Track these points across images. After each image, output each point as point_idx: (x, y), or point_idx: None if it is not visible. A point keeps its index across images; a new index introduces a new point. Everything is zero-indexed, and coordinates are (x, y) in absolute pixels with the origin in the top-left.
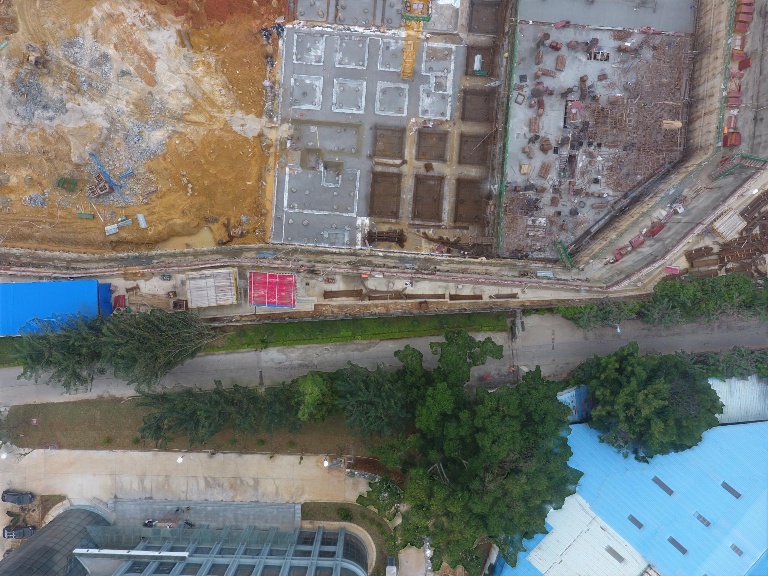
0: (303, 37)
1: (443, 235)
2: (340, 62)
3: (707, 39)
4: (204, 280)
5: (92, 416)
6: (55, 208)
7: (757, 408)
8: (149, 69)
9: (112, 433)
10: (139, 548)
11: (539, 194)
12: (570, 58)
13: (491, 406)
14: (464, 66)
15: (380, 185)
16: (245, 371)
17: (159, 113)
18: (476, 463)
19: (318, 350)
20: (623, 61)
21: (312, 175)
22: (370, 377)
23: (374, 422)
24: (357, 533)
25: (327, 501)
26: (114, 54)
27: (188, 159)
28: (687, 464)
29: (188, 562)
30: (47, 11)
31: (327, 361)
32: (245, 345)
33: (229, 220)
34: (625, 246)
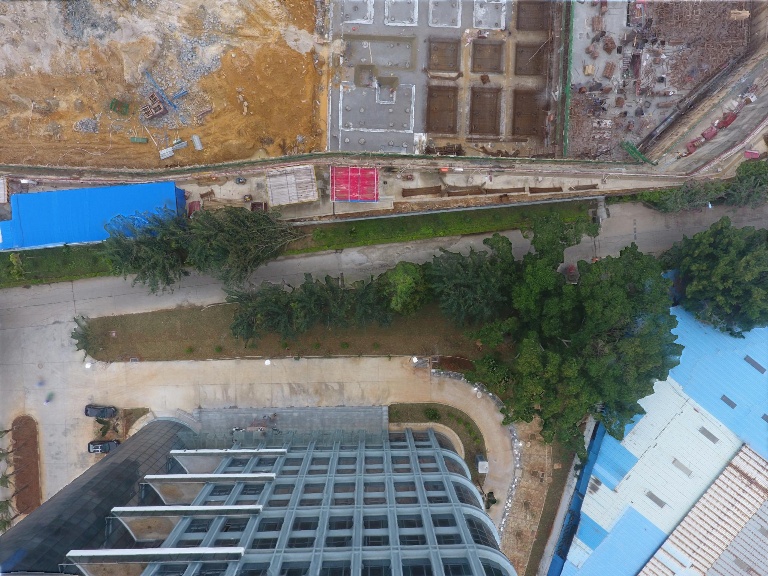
0: None
1: (502, 149)
2: None
3: None
4: (284, 177)
5: (172, 326)
6: (107, 133)
7: None
8: None
9: (194, 342)
10: (235, 448)
11: (604, 95)
12: None
13: (599, 273)
14: None
15: (436, 100)
16: (326, 274)
17: (212, 28)
18: (583, 335)
19: (399, 249)
20: None
21: (366, 92)
22: (466, 260)
23: (472, 304)
24: (445, 433)
25: (414, 402)
26: None
27: (243, 75)
28: None
29: (287, 457)
30: None
31: (408, 260)
32: (325, 246)
33: (285, 141)
34: (697, 139)
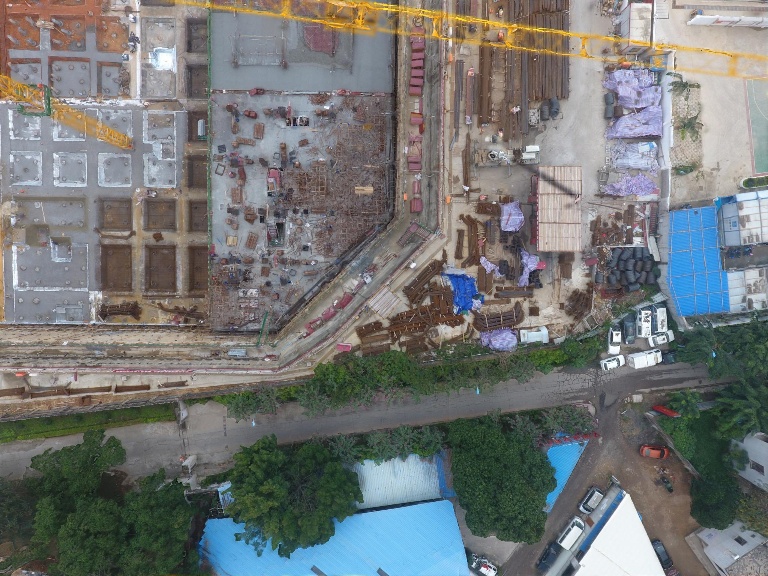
0: None
1: (179, 305)
2: (60, 135)
3: (397, 101)
4: None
5: None
6: None
7: (423, 487)
8: None
9: None
10: None
11: (249, 265)
12: (269, 125)
13: (71, 526)
14: (185, 133)
15: (112, 257)
16: None
17: None
18: None
19: None
20: (323, 125)
21: (41, 251)
22: None
23: None
24: None
25: None
26: None
27: None
28: (345, 552)
29: None
30: None
31: None
32: None
33: None
34: (318, 319)
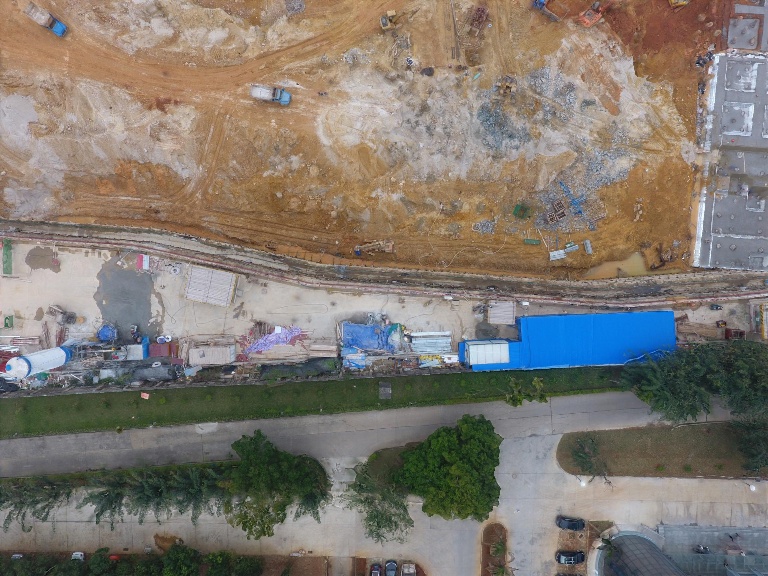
0: (733, 65)
1: None
2: None
3: None
4: None
5: (643, 443)
6: (502, 234)
7: None
8: (613, 99)
9: (662, 460)
10: (739, 575)
11: None
12: None
13: None
14: None
15: None
16: None
17: (621, 141)
18: None
19: None
20: None
21: (737, 200)
22: None
23: None
24: None
25: None
26: (581, 84)
27: (646, 186)
28: None
29: None
30: (518, 43)
31: None
32: None
33: (662, 245)
34: None
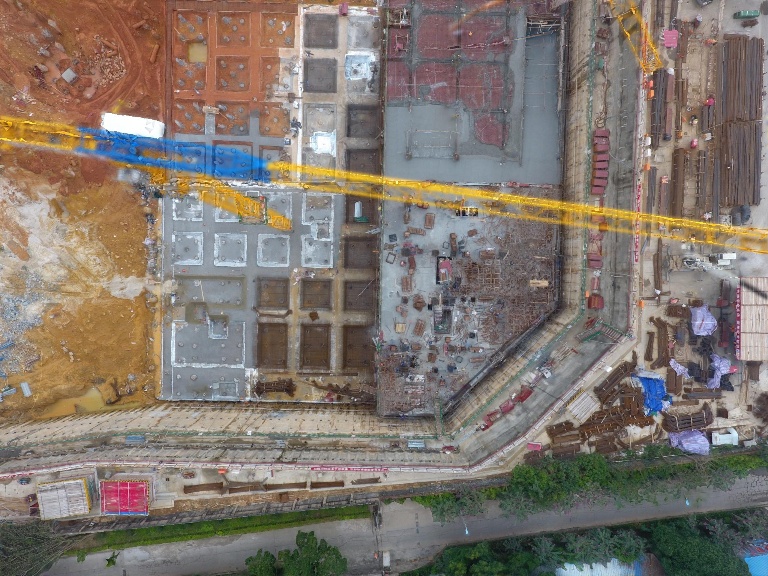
0: None
1: (332, 382)
2: (220, 216)
3: (571, 195)
4: (55, 492)
5: None
6: None
7: None
8: (22, 244)
9: None
10: None
11: (416, 351)
12: (439, 215)
13: None
14: (343, 215)
15: (267, 335)
16: (108, 571)
17: (34, 286)
18: None
19: (181, 546)
20: (492, 215)
21: (199, 329)
22: None
23: None
24: None
25: None
26: None
27: (66, 329)
28: None
29: None
30: None
31: (190, 556)
32: (106, 546)
33: (116, 380)
34: (496, 411)
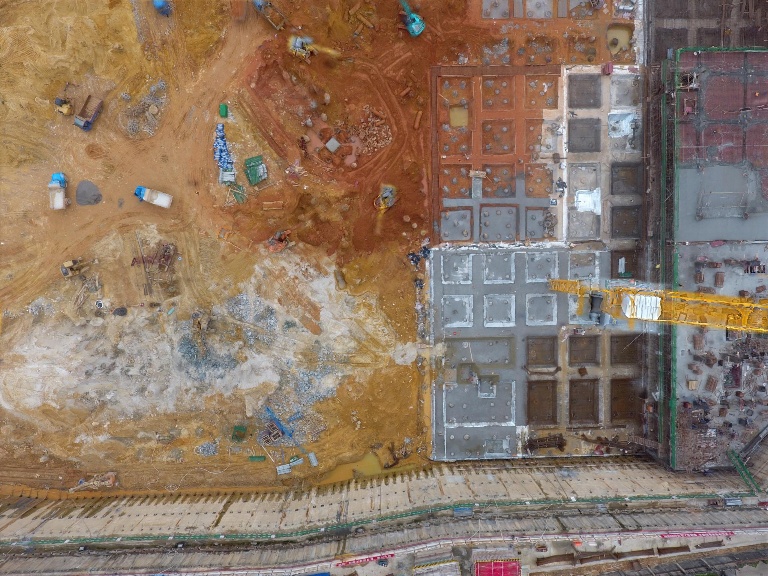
0: (449, 257)
1: (601, 435)
2: (487, 278)
3: None
4: (431, 574)
5: None
6: (226, 454)
7: None
8: (314, 318)
9: None
10: None
11: None
12: (728, 273)
13: None
14: (610, 272)
15: (535, 391)
16: None
17: (326, 359)
18: None
19: None
20: None
21: (468, 389)
22: None
23: None
24: None
25: None
26: (279, 308)
27: (357, 400)
28: None
29: None
30: (210, 273)
31: None
32: None
33: (393, 444)
34: None
